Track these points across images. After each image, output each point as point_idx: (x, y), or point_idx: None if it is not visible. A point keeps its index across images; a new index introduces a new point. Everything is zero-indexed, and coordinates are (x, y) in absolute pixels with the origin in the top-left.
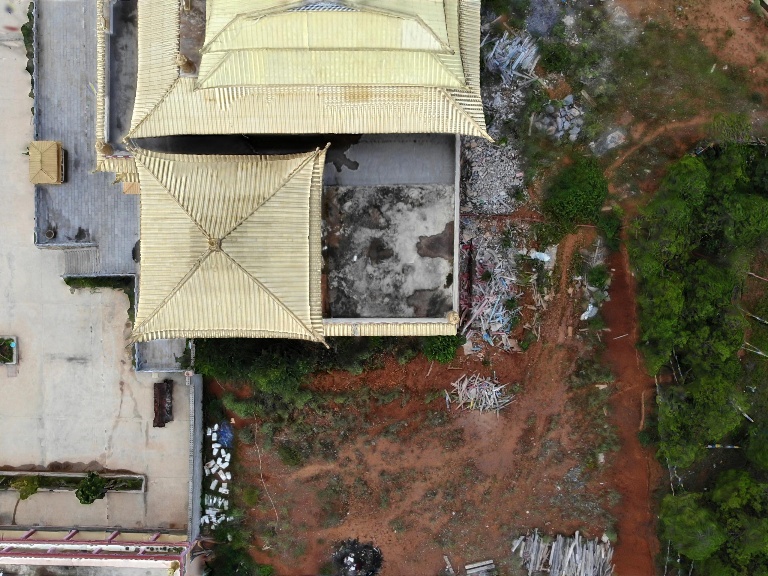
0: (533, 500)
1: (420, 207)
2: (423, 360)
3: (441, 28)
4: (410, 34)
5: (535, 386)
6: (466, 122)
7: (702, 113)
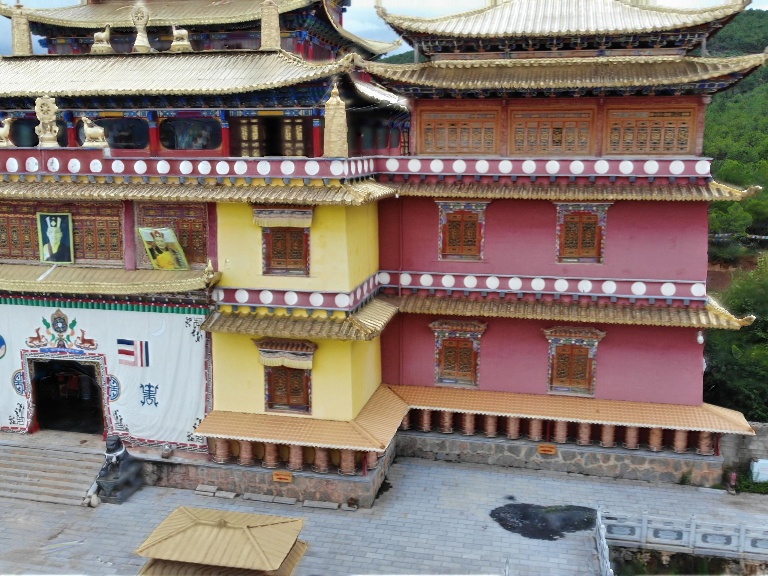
0: None
1: None
2: None
3: None
4: None
5: None
6: None
7: None
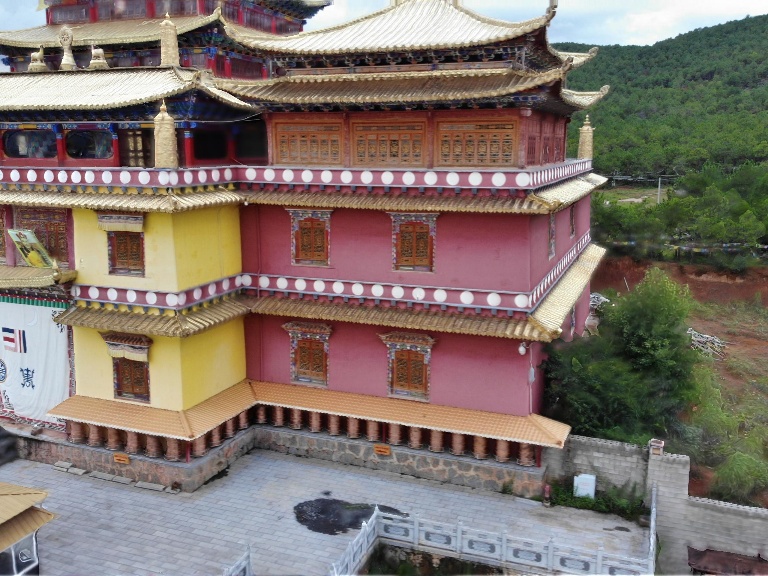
0: None
1: None
2: None
3: None
4: None
5: None
6: None
7: None
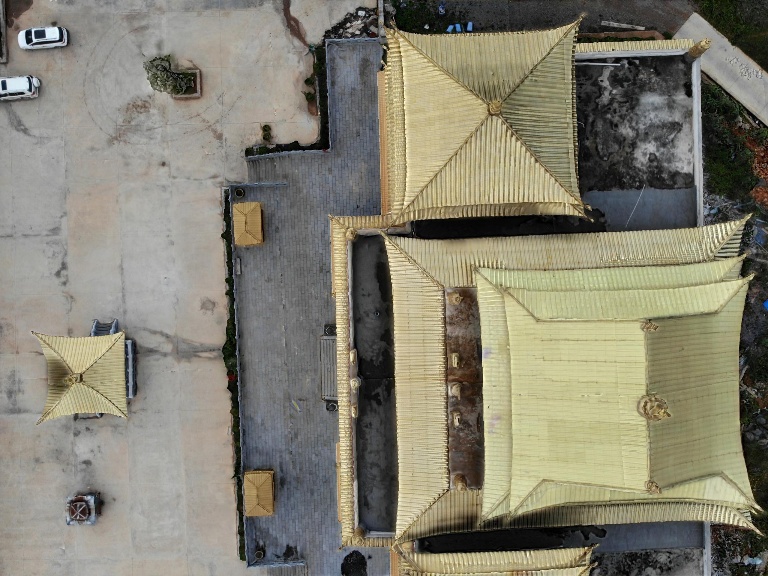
0: None
1: (669, 571)
2: None
3: (744, 481)
4: (714, 488)
5: None
6: (732, 514)
7: None
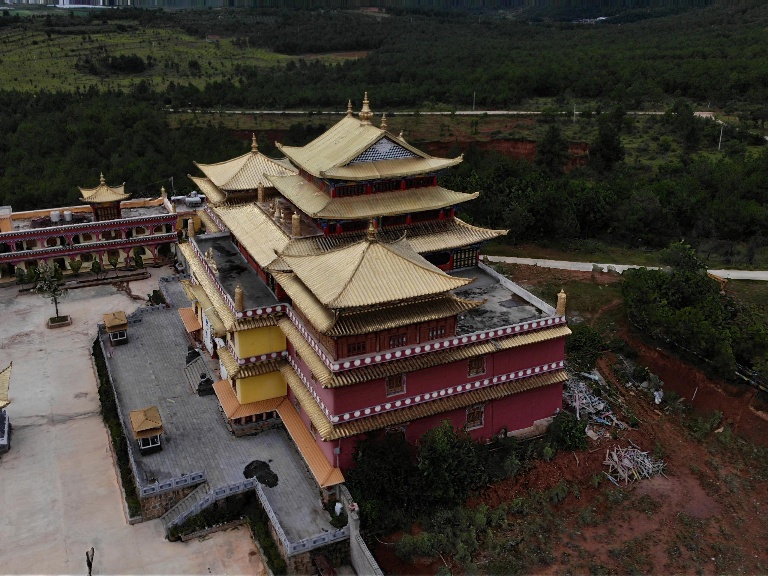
0: (767, 520)
1: None
2: (564, 454)
3: None
4: None
5: (672, 450)
6: (484, 232)
7: (615, 299)
